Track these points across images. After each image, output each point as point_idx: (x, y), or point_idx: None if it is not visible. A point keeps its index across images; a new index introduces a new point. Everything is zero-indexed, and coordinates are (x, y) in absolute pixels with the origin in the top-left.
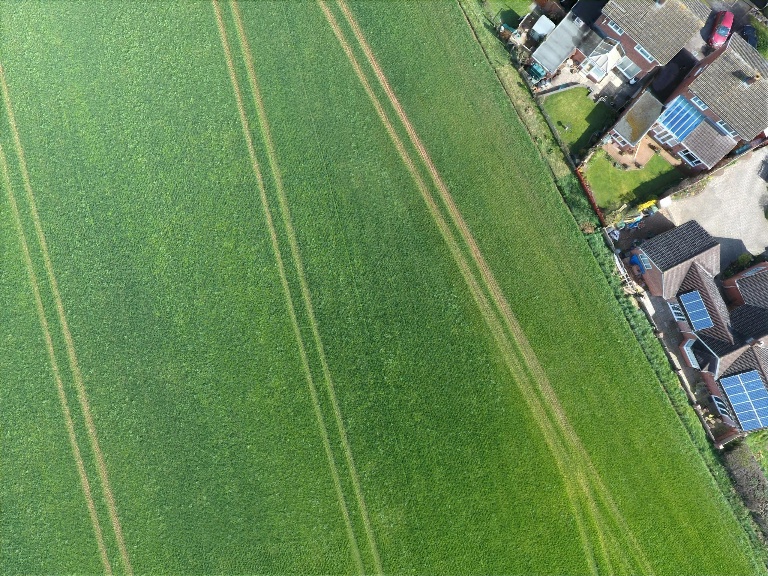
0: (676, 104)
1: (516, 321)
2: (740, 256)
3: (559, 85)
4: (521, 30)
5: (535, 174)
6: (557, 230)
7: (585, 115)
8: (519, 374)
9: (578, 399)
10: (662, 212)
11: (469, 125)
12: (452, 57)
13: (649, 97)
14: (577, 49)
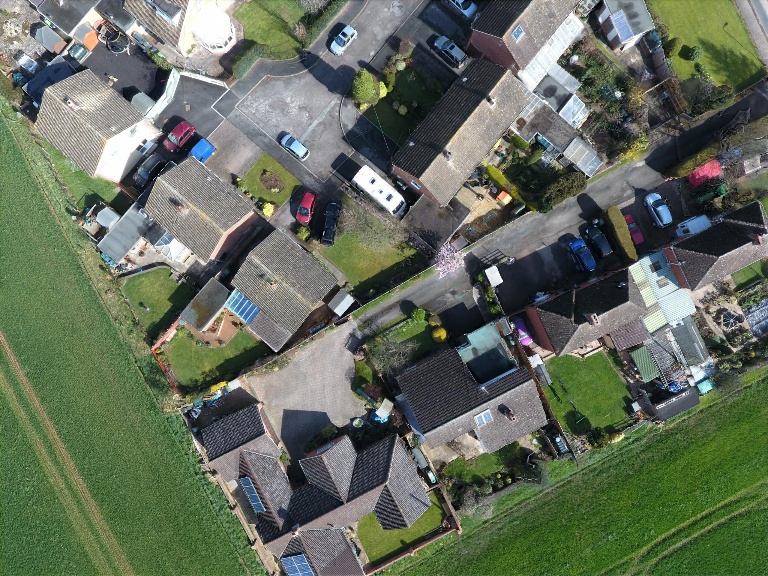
0: (238, 292)
1: (92, 500)
2: (323, 429)
3: (145, 265)
4: (95, 218)
5: (115, 355)
6: (136, 409)
7: (167, 295)
8: (95, 552)
9: (155, 574)
10: (245, 388)
11: (49, 309)
12: (34, 242)
13: (215, 284)
14: (144, 238)
